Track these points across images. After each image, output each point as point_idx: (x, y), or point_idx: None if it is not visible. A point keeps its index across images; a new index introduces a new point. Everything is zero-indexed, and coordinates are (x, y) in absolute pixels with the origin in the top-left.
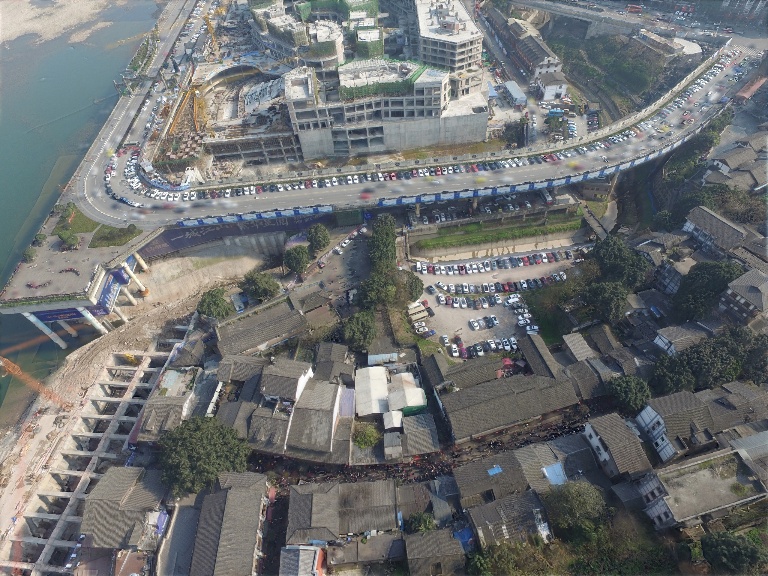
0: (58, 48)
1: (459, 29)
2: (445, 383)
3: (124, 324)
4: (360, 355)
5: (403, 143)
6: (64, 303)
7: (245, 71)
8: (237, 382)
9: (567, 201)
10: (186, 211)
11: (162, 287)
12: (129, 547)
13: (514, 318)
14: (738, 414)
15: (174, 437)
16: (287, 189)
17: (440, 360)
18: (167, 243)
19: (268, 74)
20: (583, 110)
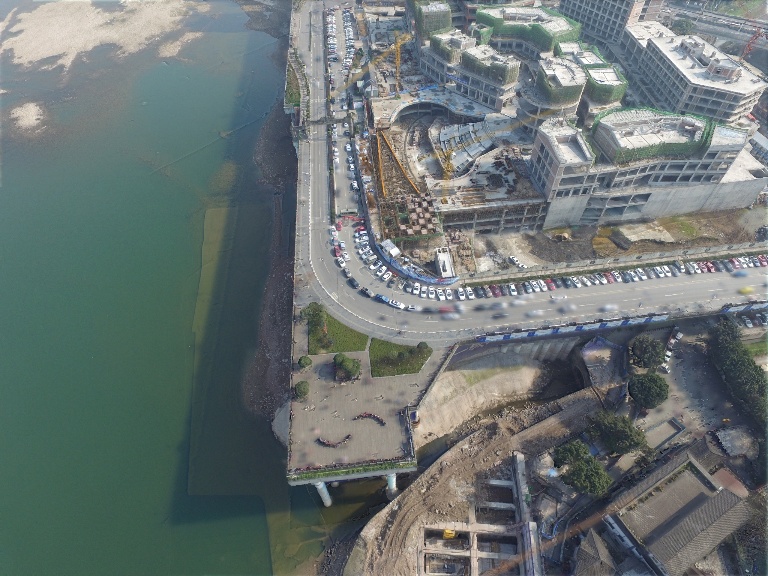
0: (148, 63)
1: (739, 76)
2: None
3: (419, 478)
4: None
5: (662, 210)
6: (381, 471)
7: (421, 108)
8: None
9: None
10: (471, 316)
11: (434, 413)
12: None
13: None
14: None
15: None
16: (586, 284)
17: None
18: None
19: (462, 115)
20: None
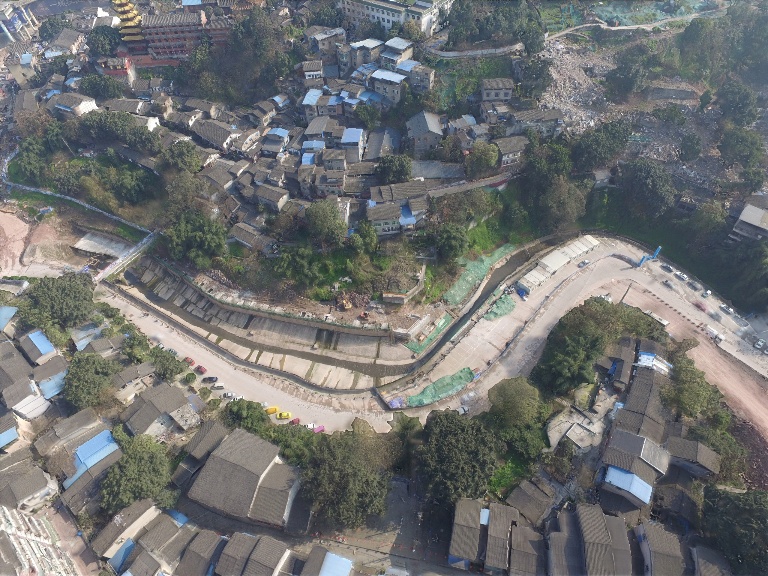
0: None
1: None
2: None
3: None
4: None
5: None
6: None
7: None
8: None
9: None
10: None
11: None
12: None
13: None
14: None
15: None
16: None
17: None
18: (48, 8)
19: None
20: None
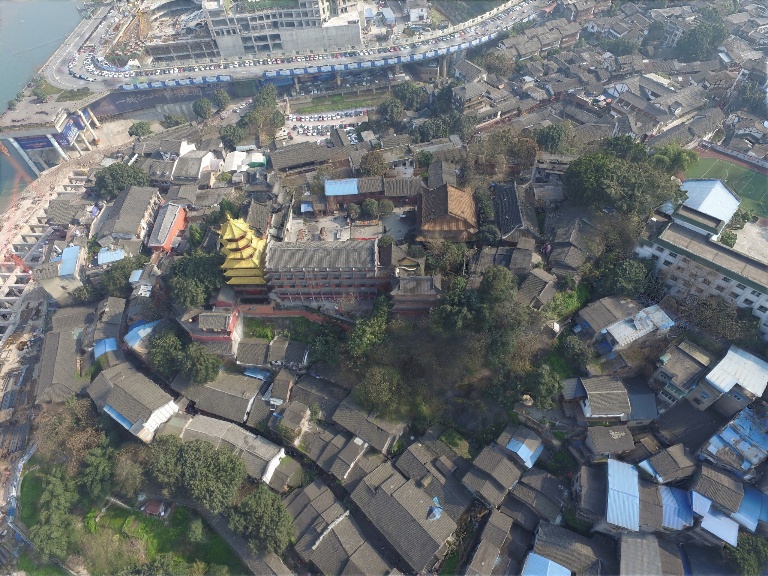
0: None
1: None
2: (277, 151)
3: None
4: (233, 150)
5: (297, 49)
6: (38, 130)
7: (184, 5)
8: (148, 155)
9: (404, 78)
10: None
11: (110, 139)
12: (75, 223)
13: None
14: None
15: (103, 170)
16: (201, 69)
17: (278, 143)
18: (113, 105)
19: (200, 5)
20: (436, 26)
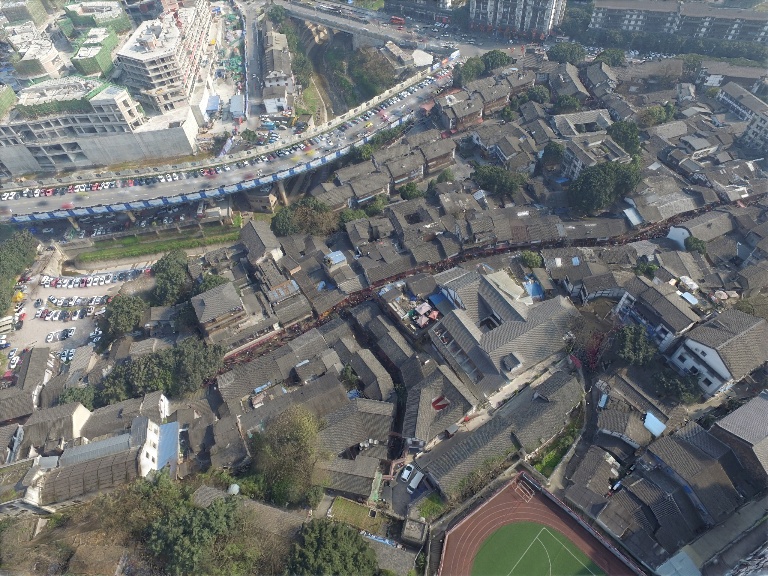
0: None
1: (152, 47)
2: None
3: None
4: None
5: (108, 158)
6: None
7: None
8: None
9: (217, 214)
10: None
11: None
12: None
13: (92, 330)
14: (122, 422)
15: None
16: None
17: None
18: None
19: None
20: (293, 123)
